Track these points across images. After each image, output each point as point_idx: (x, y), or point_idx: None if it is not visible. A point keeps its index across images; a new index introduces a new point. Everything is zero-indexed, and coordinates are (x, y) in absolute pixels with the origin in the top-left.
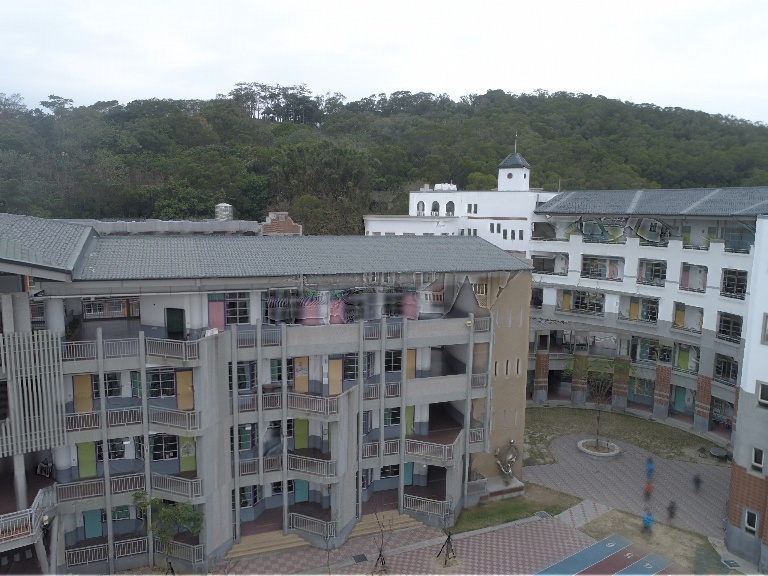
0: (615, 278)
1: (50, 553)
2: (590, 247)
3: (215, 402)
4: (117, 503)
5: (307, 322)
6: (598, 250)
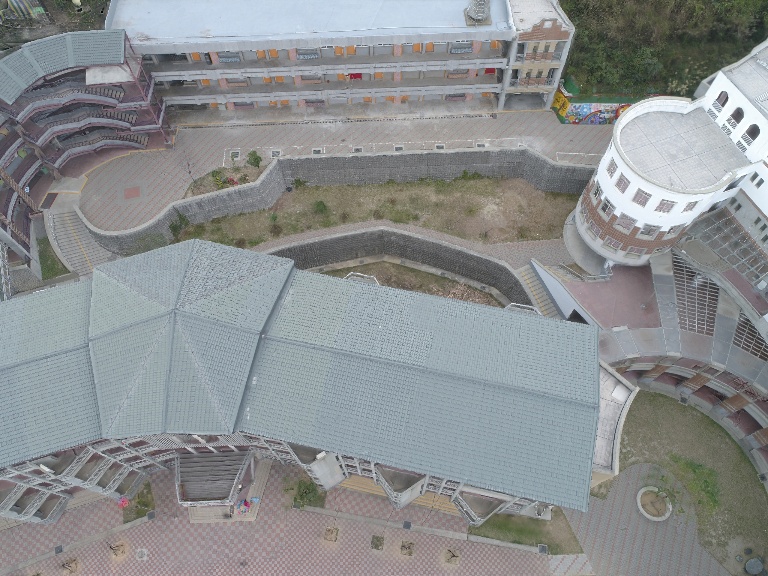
0: None
1: (251, 468)
2: None
3: None
4: (282, 457)
5: None
6: None
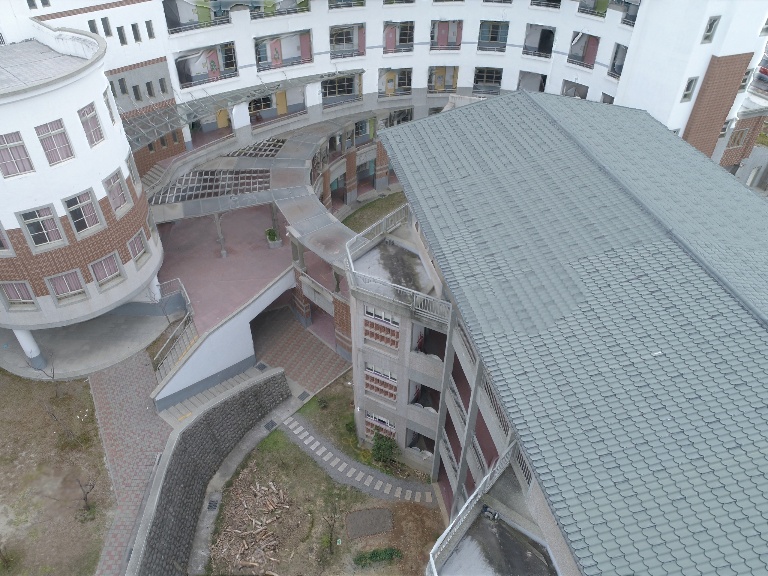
0: (304, 60)
1: None
2: (264, 25)
3: None
4: None
5: (463, 378)
6: (276, 27)
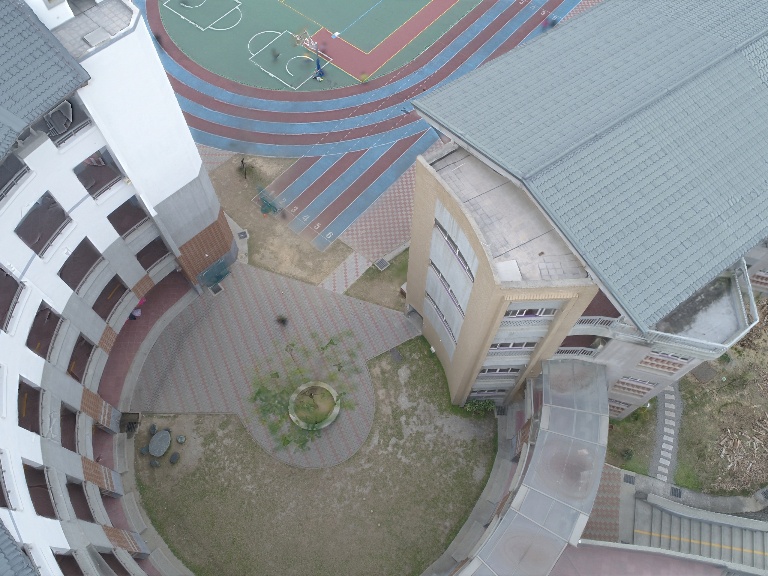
0: None
1: None
2: None
3: None
4: None
5: None
6: None
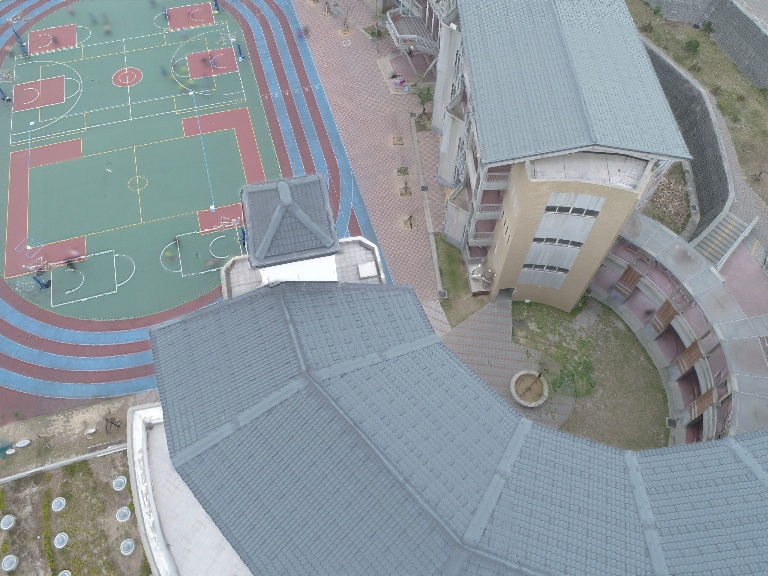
0: None
1: None
2: None
3: (446, 62)
4: None
5: None
6: None
